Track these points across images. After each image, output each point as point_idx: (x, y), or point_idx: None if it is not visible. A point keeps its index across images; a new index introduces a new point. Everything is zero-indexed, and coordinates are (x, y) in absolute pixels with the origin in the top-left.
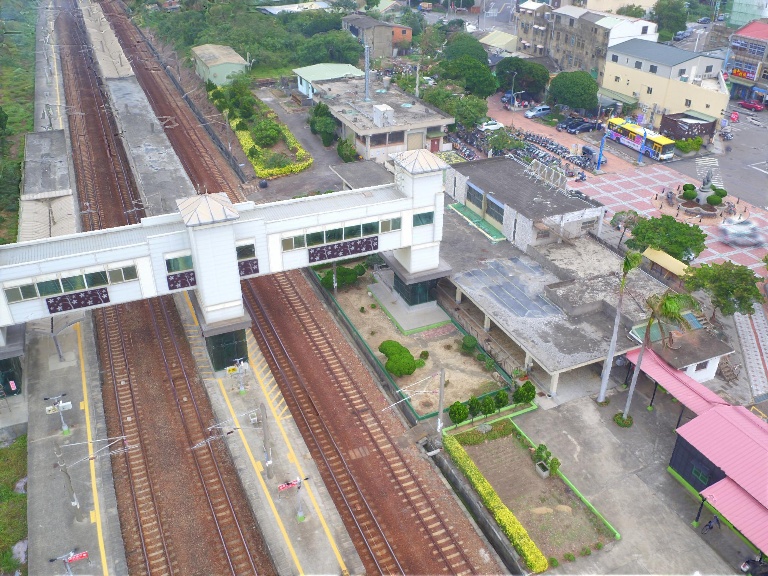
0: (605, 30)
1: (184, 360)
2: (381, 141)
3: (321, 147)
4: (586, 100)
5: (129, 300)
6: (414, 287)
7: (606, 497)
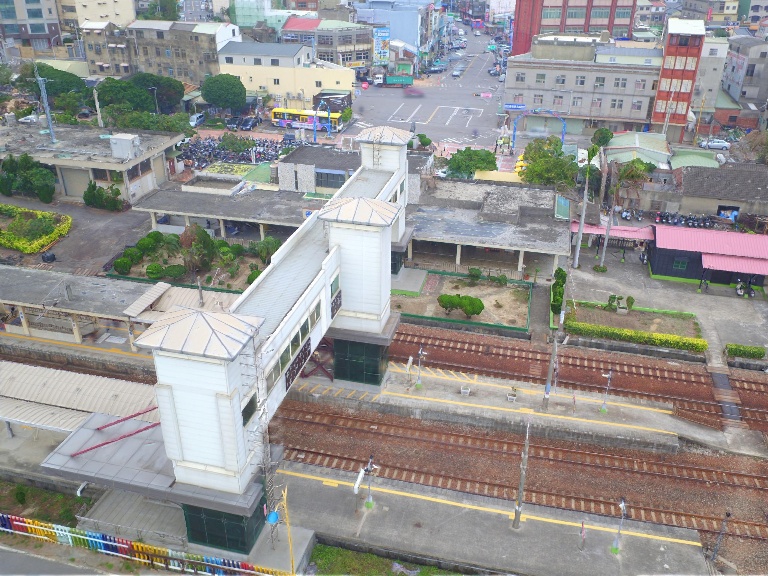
0: (209, 36)
1: (307, 409)
2: (134, 173)
3: (42, 205)
4: (244, 98)
5: (316, 345)
6: (398, 255)
7: (659, 304)
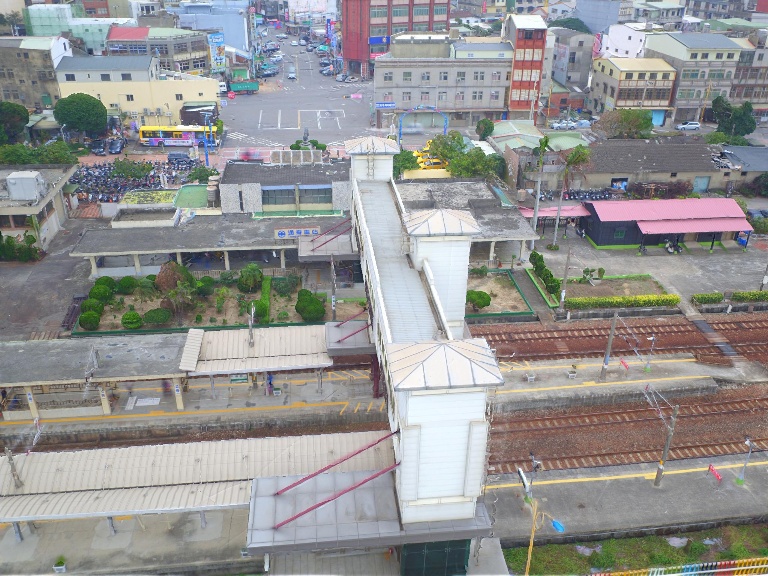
0: (42, 52)
1: None
2: (40, 216)
3: None
4: (106, 119)
5: None
6: None
7: (618, 271)
